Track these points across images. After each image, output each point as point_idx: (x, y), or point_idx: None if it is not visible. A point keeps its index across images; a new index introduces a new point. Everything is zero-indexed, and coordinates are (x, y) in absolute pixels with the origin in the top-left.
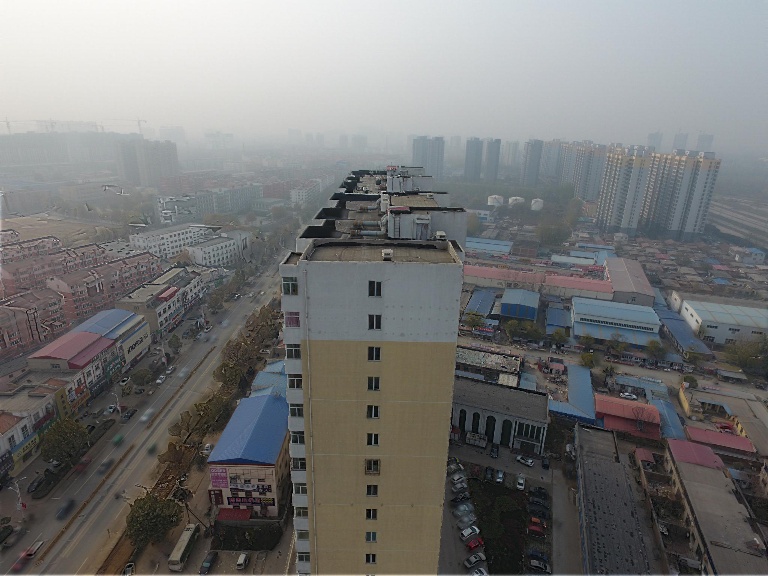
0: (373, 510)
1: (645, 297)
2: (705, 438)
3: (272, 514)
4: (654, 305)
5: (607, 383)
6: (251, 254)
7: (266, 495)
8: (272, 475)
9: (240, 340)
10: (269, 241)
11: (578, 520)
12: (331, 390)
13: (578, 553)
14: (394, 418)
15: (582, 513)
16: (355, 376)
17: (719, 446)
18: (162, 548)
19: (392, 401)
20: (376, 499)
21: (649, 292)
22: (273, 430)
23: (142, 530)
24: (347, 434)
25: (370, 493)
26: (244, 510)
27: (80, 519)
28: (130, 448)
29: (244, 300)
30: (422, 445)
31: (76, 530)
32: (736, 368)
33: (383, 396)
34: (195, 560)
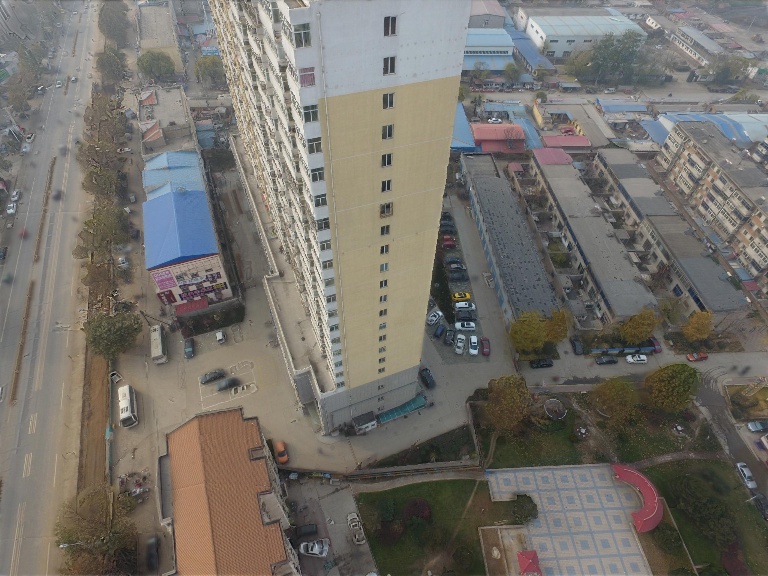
0: (386, 246)
1: (497, 18)
2: (557, 143)
3: (227, 296)
4: (504, 26)
5: (477, 113)
6: (21, 25)
7: (217, 282)
8: (218, 263)
9: (90, 142)
10: (36, 2)
11: (476, 228)
12: (349, 147)
13: (481, 251)
14: (405, 162)
15: (480, 222)
16: (371, 128)
17: (566, 147)
18: (135, 352)
19: (404, 146)
20: (389, 236)
21: (500, 12)
22: (198, 224)
23: (110, 344)
24: (365, 186)
25: (383, 233)
26: (199, 300)
27: (27, 358)
28: (31, 285)
29: (54, 93)
30: (427, 181)
31: (31, 368)
32: (573, 78)
33: (396, 143)
34: (175, 350)
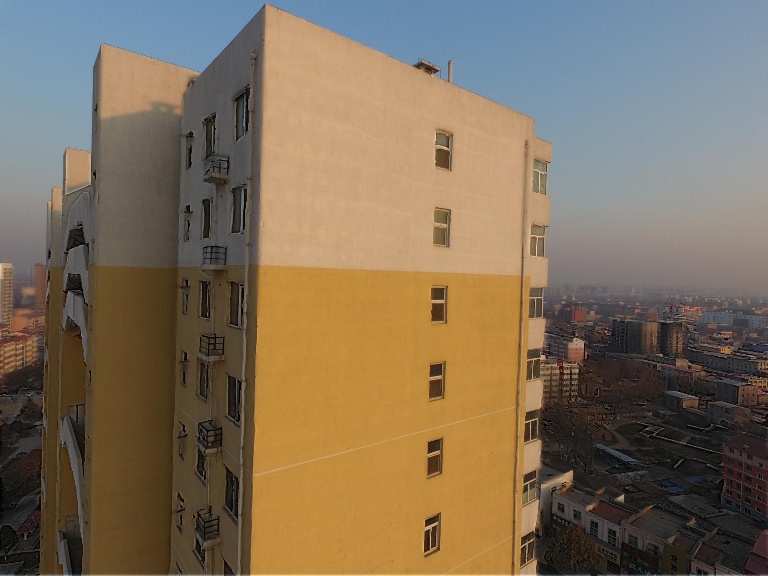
0: None
1: None
2: None
3: None
4: None
5: None
6: None
7: None
8: None
9: None
10: None
11: None
12: None
13: None
14: None
15: None
16: None
17: None
18: None
19: None
20: None
21: None
22: None
23: None
24: None
25: None
26: None
27: None
28: None
29: None
30: None
31: None
32: None
33: None
34: None
